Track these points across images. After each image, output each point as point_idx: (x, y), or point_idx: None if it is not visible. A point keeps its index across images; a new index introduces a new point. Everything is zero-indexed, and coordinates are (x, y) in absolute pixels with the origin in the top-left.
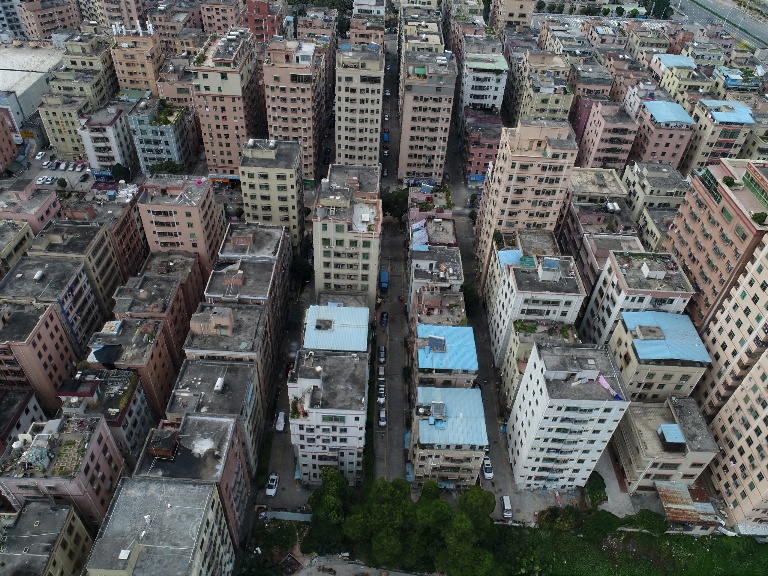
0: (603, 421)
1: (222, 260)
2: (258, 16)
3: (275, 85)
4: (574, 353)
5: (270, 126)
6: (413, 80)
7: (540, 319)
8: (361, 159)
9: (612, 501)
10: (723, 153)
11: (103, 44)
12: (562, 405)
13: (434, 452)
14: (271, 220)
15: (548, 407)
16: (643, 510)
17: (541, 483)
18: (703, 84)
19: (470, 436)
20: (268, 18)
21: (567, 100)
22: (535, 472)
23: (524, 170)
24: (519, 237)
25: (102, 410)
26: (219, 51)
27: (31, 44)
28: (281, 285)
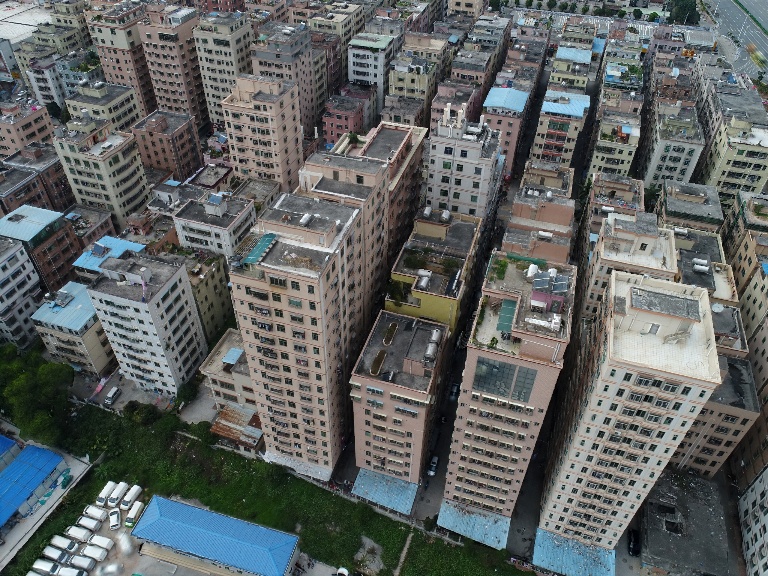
0: (143, 322)
1: (6, 167)
2: None
3: (149, 42)
4: (153, 265)
5: (152, 79)
6: (255, 45)
7: (203, 248)
8: None
9: (198, 413)
10: (557, 146)
11: None
12: (100, 298)
13: (46, 330)
14: None
15: (92, 298)
16: (204, 421)
17: (145, 383)
18: (578, 78)
19: (71, 322)
20: None
21: (422, 80)
22: (132, 369)
23: (236, 119)
24: (245, 183)
25: None
26: (115, 10)
27: None
28: (60, 198)
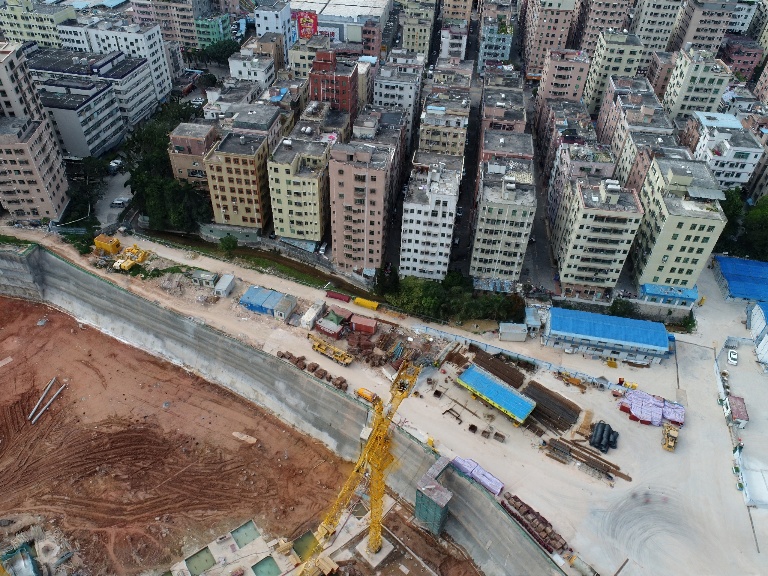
0: None
1: None
2: None
3: (602, 2)
4: None
5: (588, 34)
6: None
7: None
8: (648, 62)
9: None
10: None
11: None
12: None
13: None
14: None
15: None
16: None
17: None
18: None
19: None
20: None
21: None
22: None
23: None
24: None
25: None
26: None
27: None
28: None
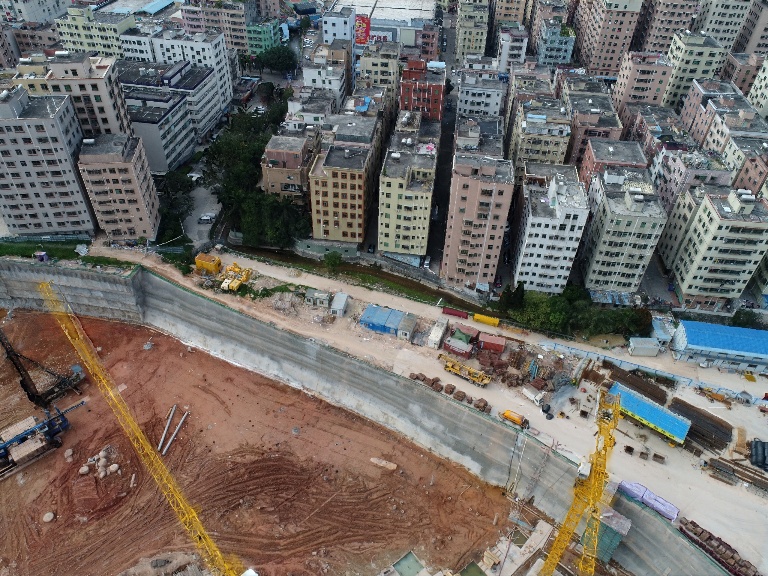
0: None
1: None
2: None
3: (670, 3)
4: None
5: (653, 35)
6: None
7: None
8: None
9: None
10: None
11: None
12: None
13: None
14: None
15: None
16: None
17: None
18: None
19: None
20: None
21: None
22: None
23: None
24: None
25: None
26: None
27: None
28: None
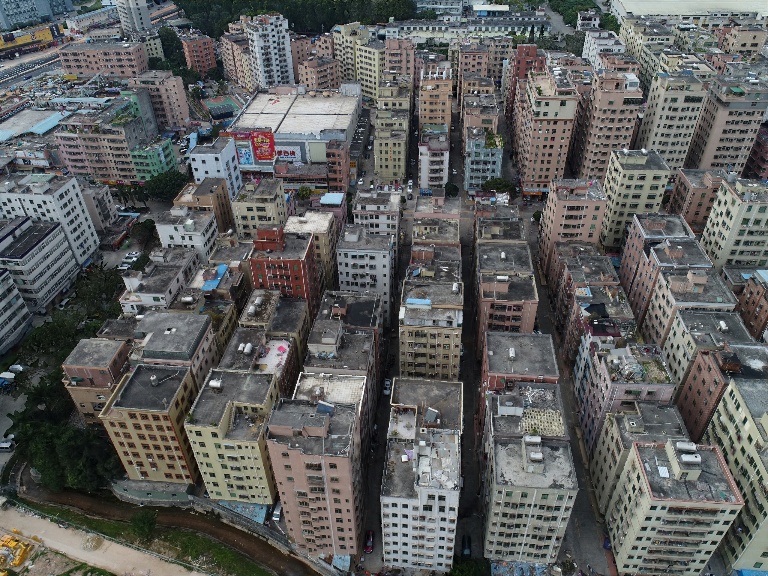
0: None
1: None
2: (530, 58)
3: (608, 108)
4: None
5: (593, 144)
6: (732, 97)
7: None
8: None
9: None
10: None
11: (403, 88)
12: None
13: None
14: None
15: None
16: None
17: None
18: None
19: None
20: (538, 59)
21: None
22: None
23: None
24: None
25: None
26: None
27: (325, 94)
28: None
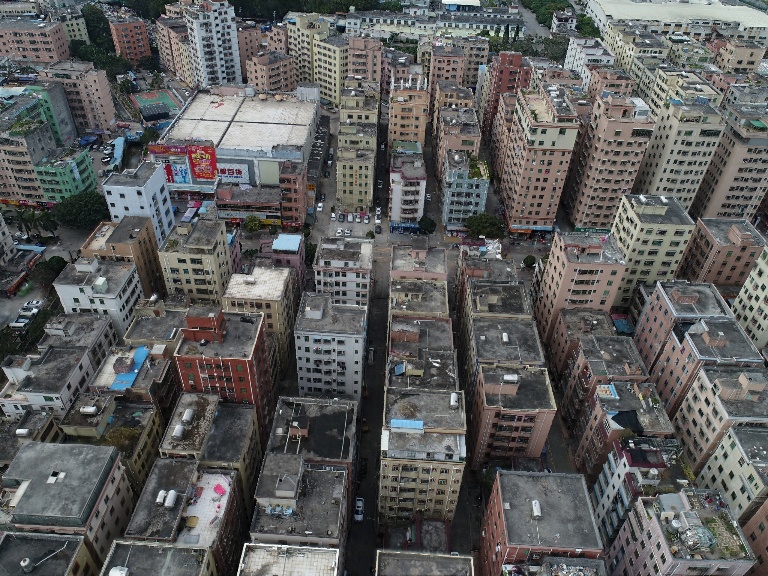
0: None
1: None
2: (514, 68)
3: (613, 139)
4: None
5: (593, 178)
6: (753, 133)
7: None
8: None
9: None
10: None
11: (370, 98)
12: None
13: None
14: (648, 275)
15: None
16: None
17: None
18: None
19: None
20: (523, 70)
21: None
22: None
23: None
24: None
25: (671, 481)
26: (554, 107)
27: (278, 97)
28: None
